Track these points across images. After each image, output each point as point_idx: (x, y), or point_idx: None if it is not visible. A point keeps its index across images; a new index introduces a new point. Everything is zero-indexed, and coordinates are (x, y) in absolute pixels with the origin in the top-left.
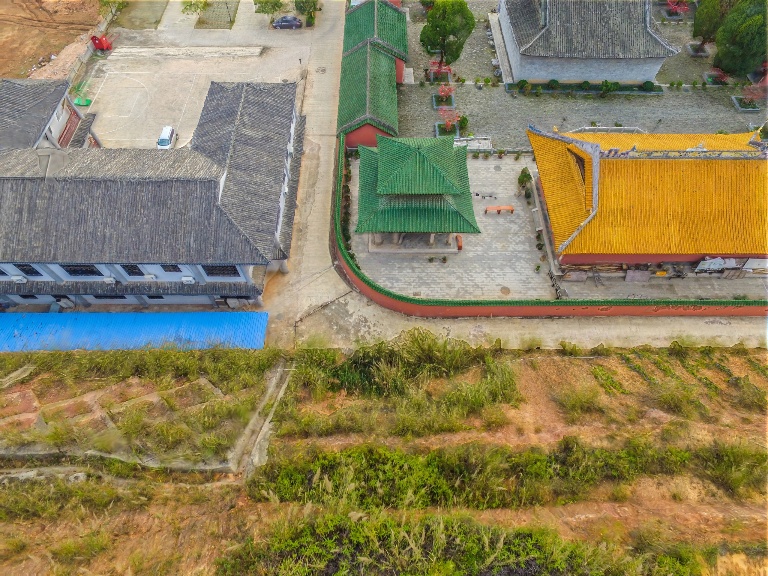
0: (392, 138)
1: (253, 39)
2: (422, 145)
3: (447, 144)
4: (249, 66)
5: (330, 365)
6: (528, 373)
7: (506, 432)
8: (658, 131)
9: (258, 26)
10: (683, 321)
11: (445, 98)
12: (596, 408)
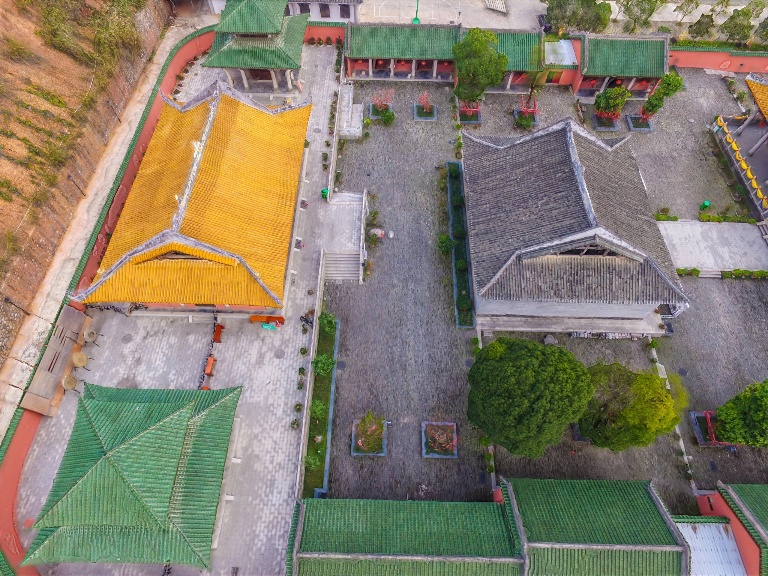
0: (283, 3)
1: (518, 8)
2: (262, 6)
3: (268, 25)
4: (470, 4)
5: (128, 4)
6: (77, 72)
7: (12, 7)
8: (380, 297)
9: (541, 10)
10: (111, 221)
11: (426, 110)
12: (12, 55)
